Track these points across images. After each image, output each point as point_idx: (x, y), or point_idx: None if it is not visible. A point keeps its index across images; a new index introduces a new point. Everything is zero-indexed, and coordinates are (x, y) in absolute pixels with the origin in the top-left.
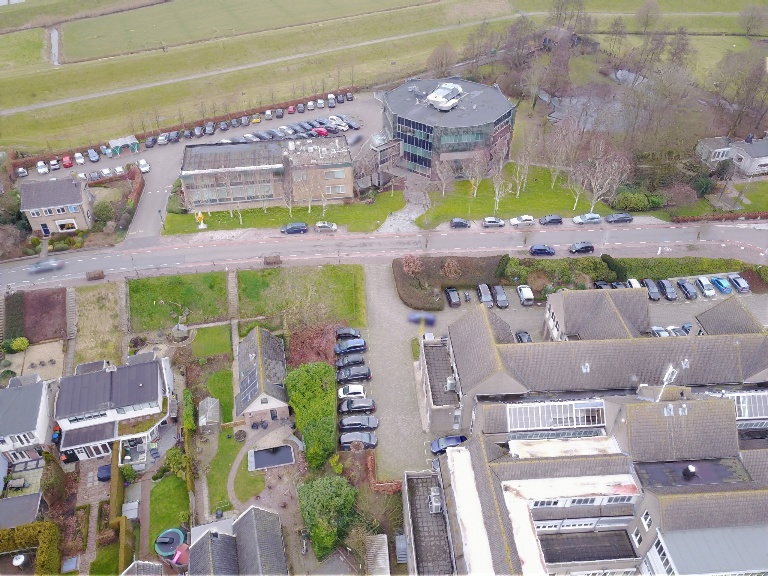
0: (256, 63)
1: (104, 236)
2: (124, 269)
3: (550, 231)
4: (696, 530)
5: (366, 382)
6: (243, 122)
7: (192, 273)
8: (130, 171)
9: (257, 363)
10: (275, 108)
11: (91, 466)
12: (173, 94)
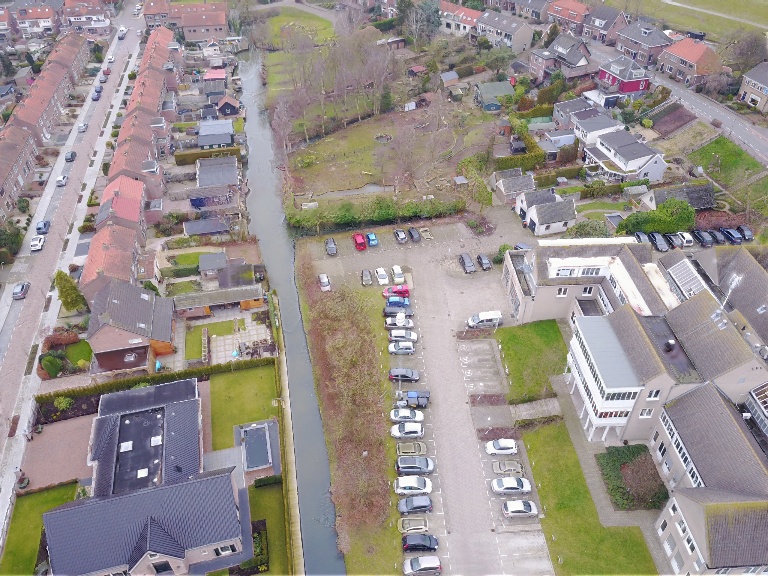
0: None
1: (761, 119)
2: (734, 133)
3: None
4: (614, 334)
5: (700, 246)
6: None
7: (752, 156)
8: None
9: None
10: None
11: None
12: None
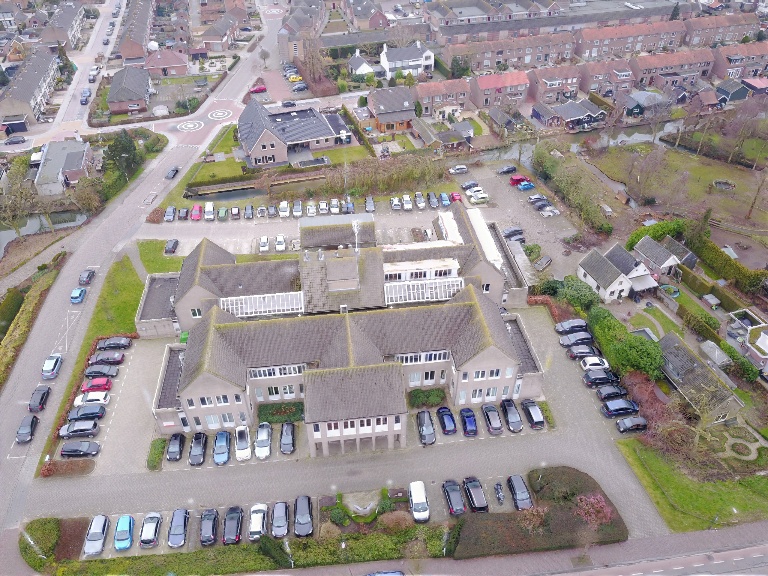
0: None
1: None
2: None
3: None
4: None
5: None
6: None
7: None
8: None
9: None
10: None
11: None
12: None
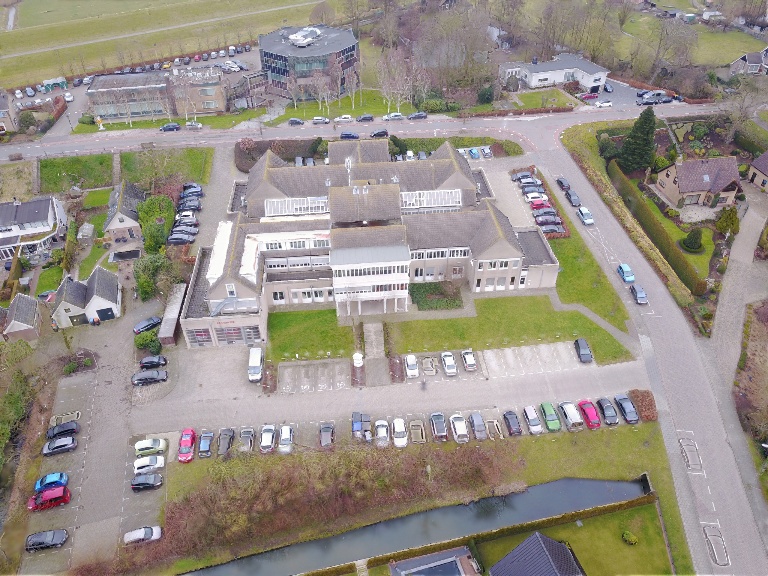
0: (176, 26)
1: (27, 136)
2: (38, 154)
3: (362, 125)
4: (352, 248)
5: (197, 212)
6: (155, 67)
7: (87, 155)
8: (56, 100)
9: (119, 198)
10: (184, 57)
11: (2, 264)
12: (103, 50)
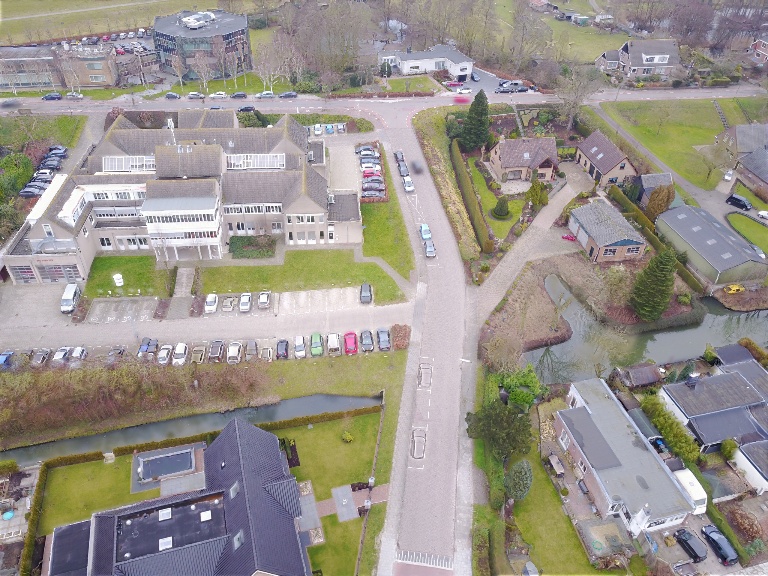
0: (93, 8)
1: None
2: None
3: (235, 101)
4: (166, 198)
5: (56, 171)
6: None
7: None
8: None
9: None
10: (92, 37)
11: None
12: (16, 27)
